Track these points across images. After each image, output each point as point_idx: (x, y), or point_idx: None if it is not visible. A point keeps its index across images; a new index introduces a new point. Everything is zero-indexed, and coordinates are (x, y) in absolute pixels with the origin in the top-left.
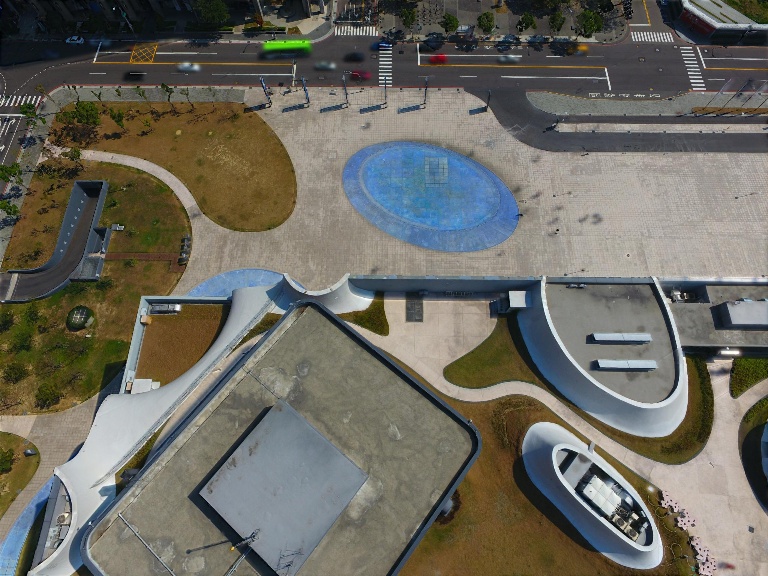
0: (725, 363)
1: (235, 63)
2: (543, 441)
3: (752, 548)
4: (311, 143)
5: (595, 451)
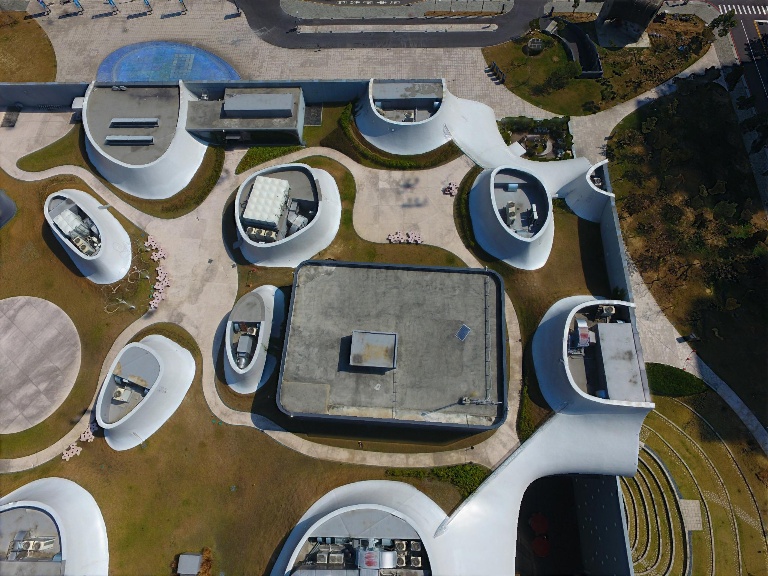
0: (242, 151)
1: None
2: None
3: (205, 273)
4: (77, 43)
5: (108, 210)
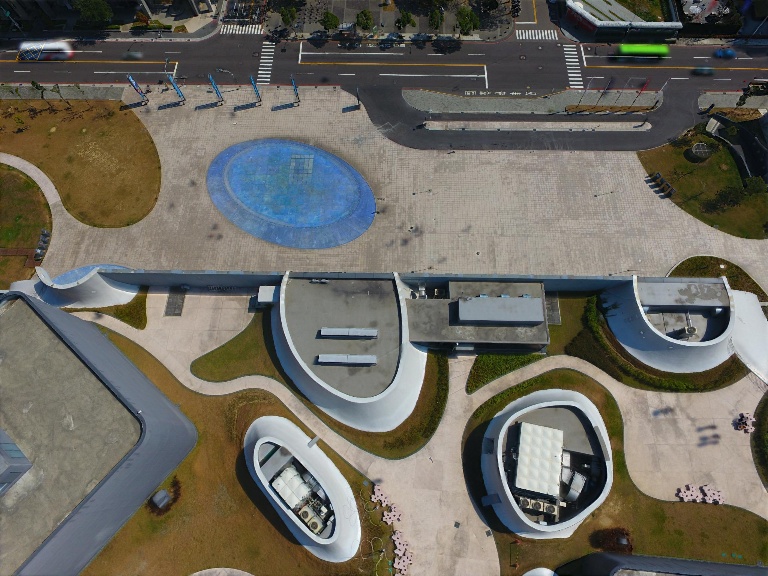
0: (468, 359)
1: (118, 61)
2: (256, 434)
3: (453, 543)
4: (181, 140)
5: (317, 445)
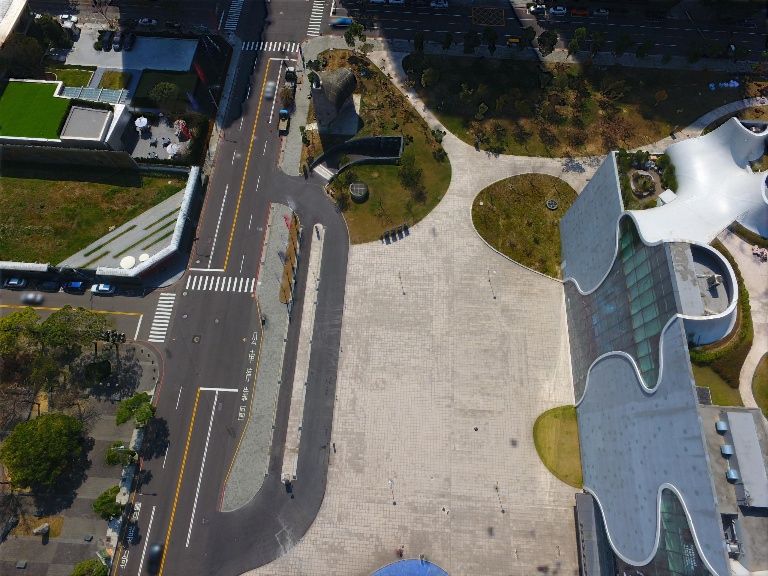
0: None
1: None
2: None
3: None
4: None
5: None
